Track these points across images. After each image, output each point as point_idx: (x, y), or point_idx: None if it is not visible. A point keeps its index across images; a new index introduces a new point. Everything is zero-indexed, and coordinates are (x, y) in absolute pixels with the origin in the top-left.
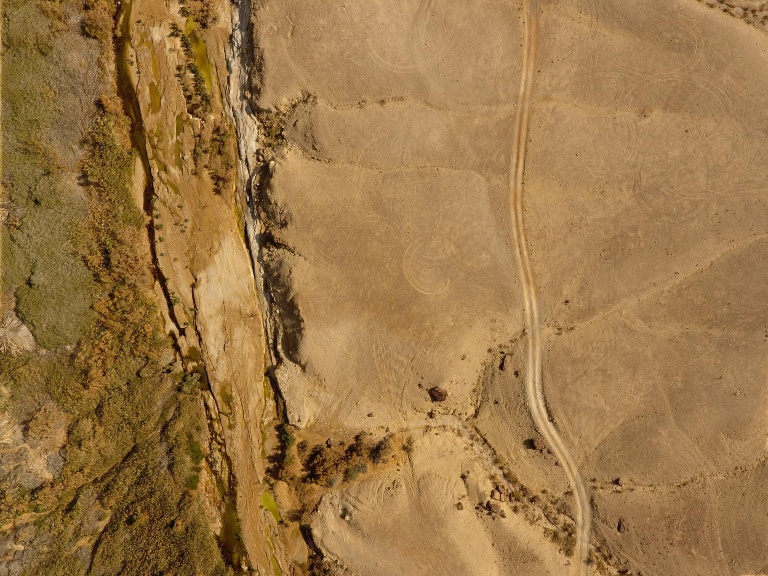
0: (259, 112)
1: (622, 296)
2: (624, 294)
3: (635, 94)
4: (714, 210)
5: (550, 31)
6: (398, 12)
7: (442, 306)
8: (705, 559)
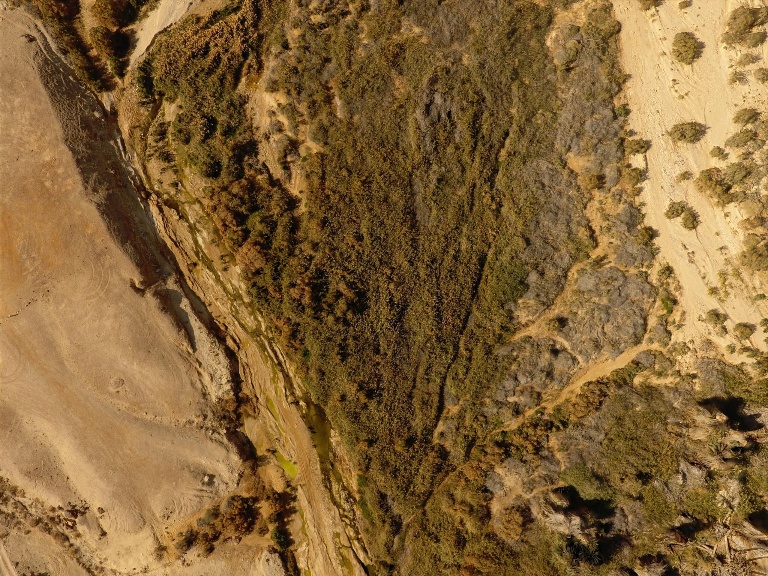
0: None
1: None
2: None
3: None
4: None
5: None
6: None
7: None
8: None
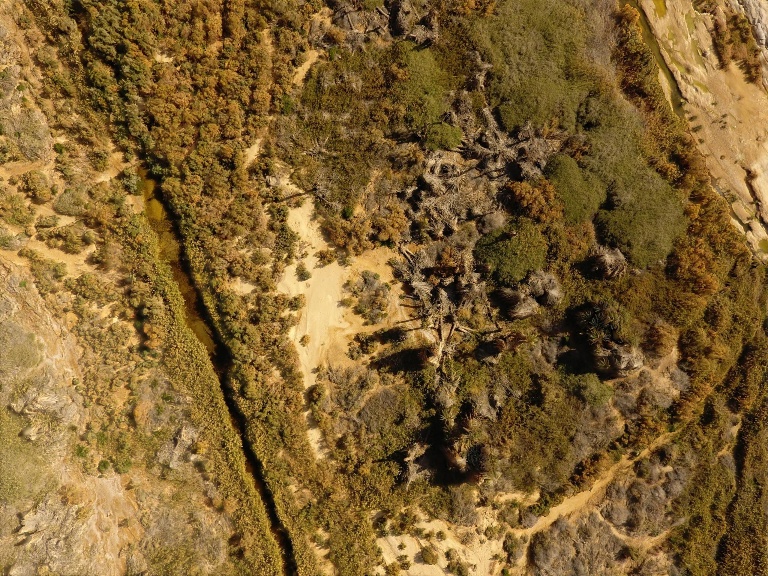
0: None
1: None
2: None
3: None
4: None
5: None
6: None
7: None
8: None
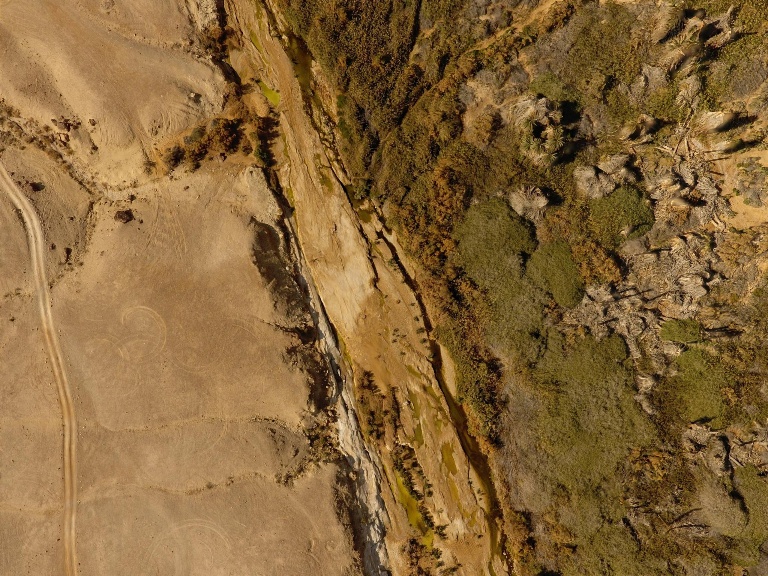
0: (338, 460)
1: None
2: None
3: None
4: None
5: None
6: None
7: (125, 297)
8: None
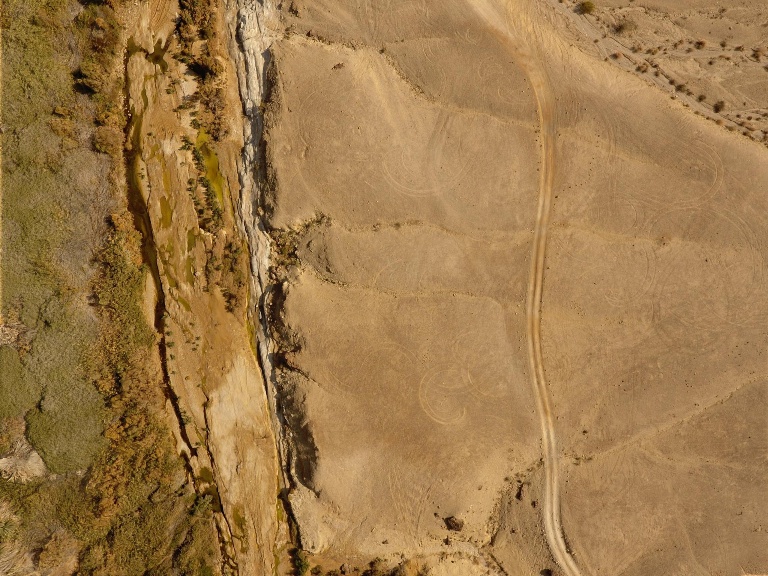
0: (272, 230)
1: (641, 427)
2: (643, 425)
3: (654, 222)
4: (734, 342)
5: (567, 155)
6: (413, 134)
7: (458, 436)
8: None
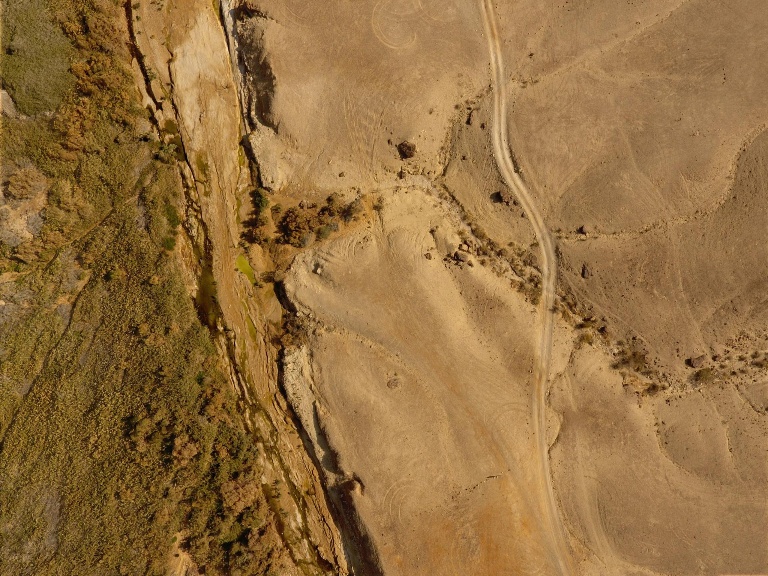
0: None
1: (585, 47)
2: (587, 45)
3: None
4: None
5: None
6: None
7: (410, 60)
8: (667, 299)
